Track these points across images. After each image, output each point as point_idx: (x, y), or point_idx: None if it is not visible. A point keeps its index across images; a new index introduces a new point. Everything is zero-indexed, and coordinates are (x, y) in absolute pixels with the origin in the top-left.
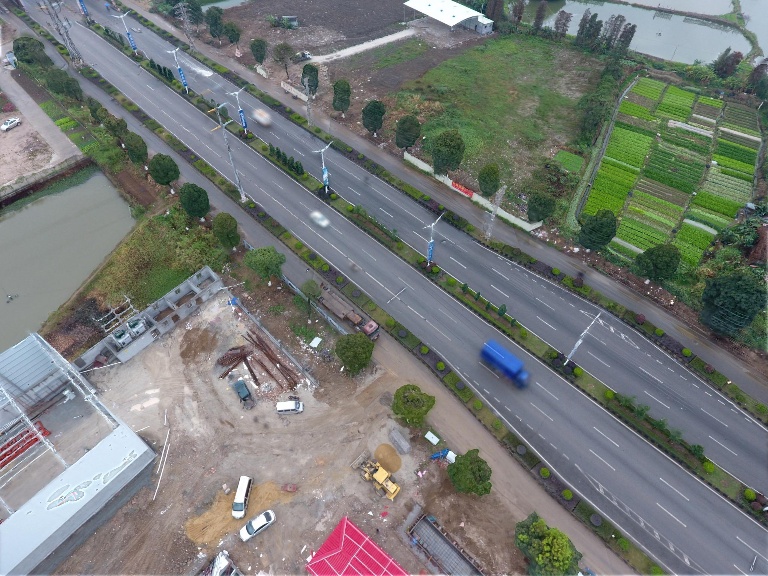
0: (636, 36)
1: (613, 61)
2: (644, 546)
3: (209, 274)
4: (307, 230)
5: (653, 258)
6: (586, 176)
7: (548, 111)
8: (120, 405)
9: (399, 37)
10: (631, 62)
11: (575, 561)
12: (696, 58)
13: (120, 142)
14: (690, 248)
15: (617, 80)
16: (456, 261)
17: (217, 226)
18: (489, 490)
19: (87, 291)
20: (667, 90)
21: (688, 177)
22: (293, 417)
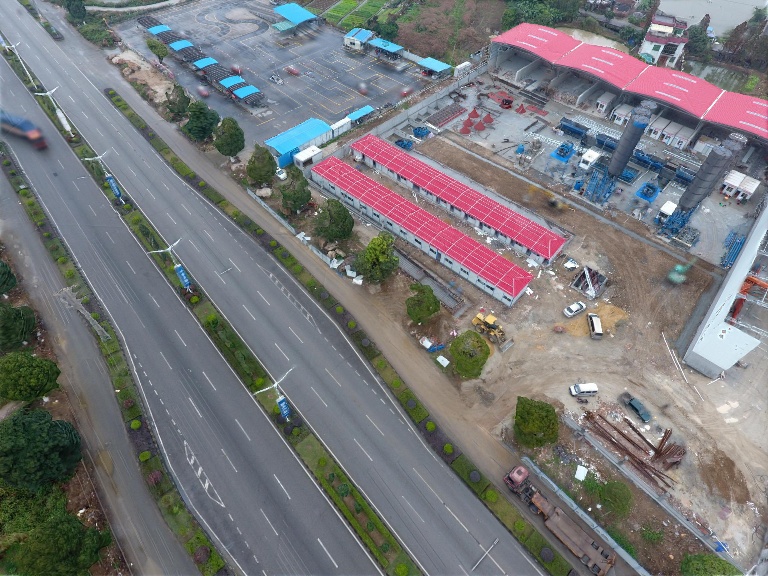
0: None
1: None
2: (296, 284)
3: None
4: None
5: (78, 541)
6: None
7: None
8: (752, 407)
9: None
10: None
11: None
12: None
13: None
14: None
15: None
16: None
17: None
18: None
19: None
20: None
21: None
22: None
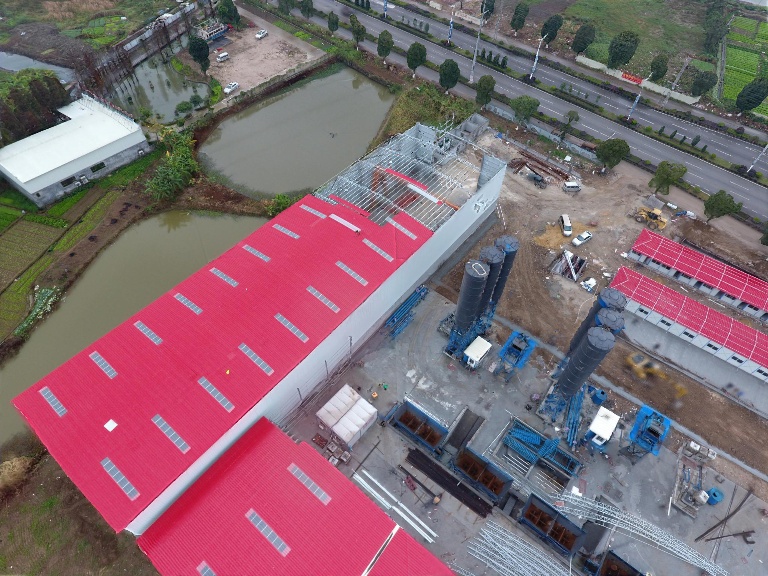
0: None
1: None
2: None
3: (475, 120)
4: None
5: None
6: (718, 75)
7: (673, 35)
8: None
9: None
10: None
11: None
12: None
13: (355, 46)
14: None
15: (722, 15)
16: (644, 120)
17: (485, 83)
18: None
19: (387, 131)
20: (760, 25)
21: None
22: (575, 193)
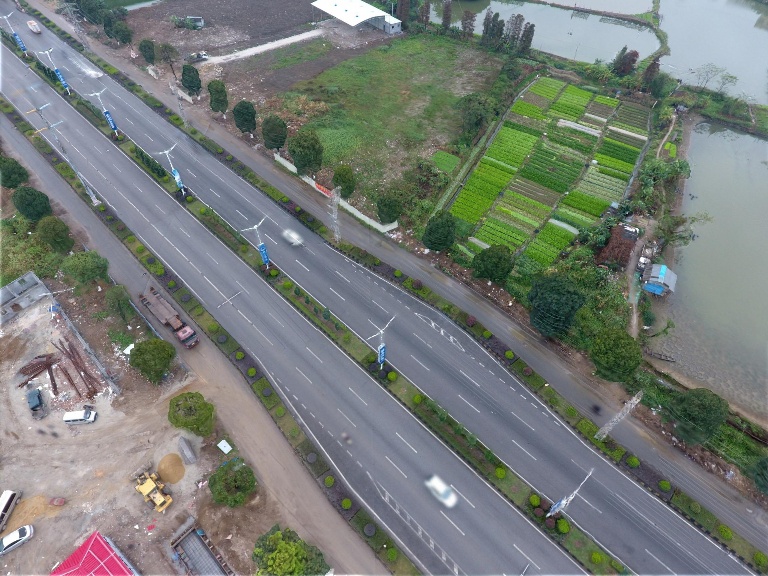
0: (537, 35)
1: (508, 60)
2: (416, 556)
3: (35, 280)
4: (155, 233)
5: (484, 259)
6: (459, 176)
7: (436, 111)
8: None
9: (304, 37)
10: (533, 61)
11: (318, 574)
12: (596, 57)
13: None
14: (547, 248)
15: (513, 79)
16: (300, 264)
17: (40, 230)
18: (240, 501)
19: None
20: (565, 89)
21: (564, 176)
22: (83, 427)
